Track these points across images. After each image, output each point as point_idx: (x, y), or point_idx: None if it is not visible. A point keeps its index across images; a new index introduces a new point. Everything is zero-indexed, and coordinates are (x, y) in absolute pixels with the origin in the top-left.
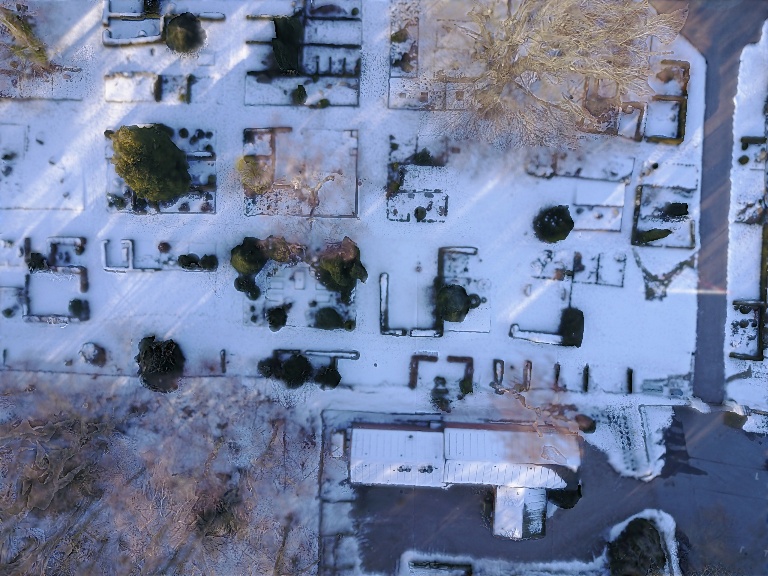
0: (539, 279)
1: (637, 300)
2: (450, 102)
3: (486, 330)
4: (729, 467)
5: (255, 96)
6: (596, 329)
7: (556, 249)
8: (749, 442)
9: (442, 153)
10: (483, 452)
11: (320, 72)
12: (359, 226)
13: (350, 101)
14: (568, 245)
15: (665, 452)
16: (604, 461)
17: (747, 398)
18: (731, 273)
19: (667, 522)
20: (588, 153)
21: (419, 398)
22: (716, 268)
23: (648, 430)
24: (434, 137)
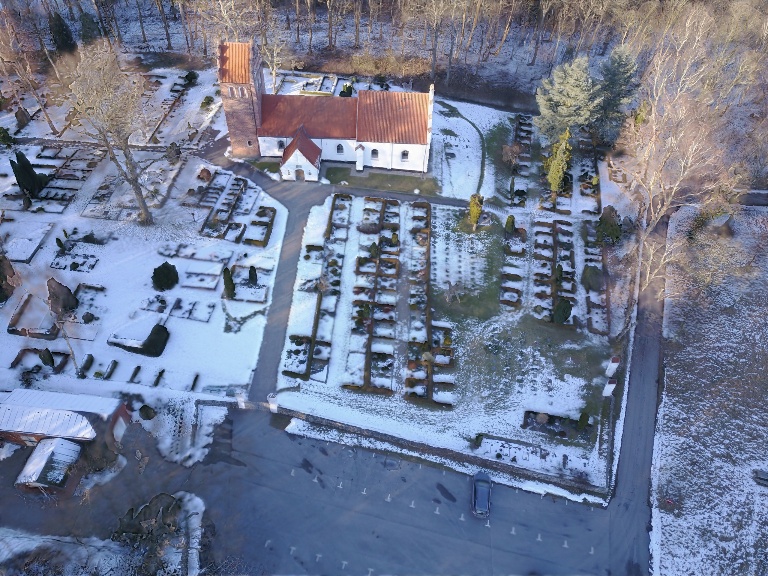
0: (145, 310)
1: (217, 332)
2: (122, 217)
3: (91, 338)
4: (268, 462)
5: (1, 206)
6: (179, 347)
7: (164, 295)
8: (289, 441)
9: (105, 238)
10: (34, 401)
11: (47, 198)
12: (28, 269)
13: (58, 210)
14: (175, 295)
15: (211, 443)
16: (154, 446)
17: (293, 407)
18: (291, 320)
19: (195, 504)
20: (203, 247)
21: (12, 377)
22: (281, 316)
23: (200, 422)
24: (104, 231)
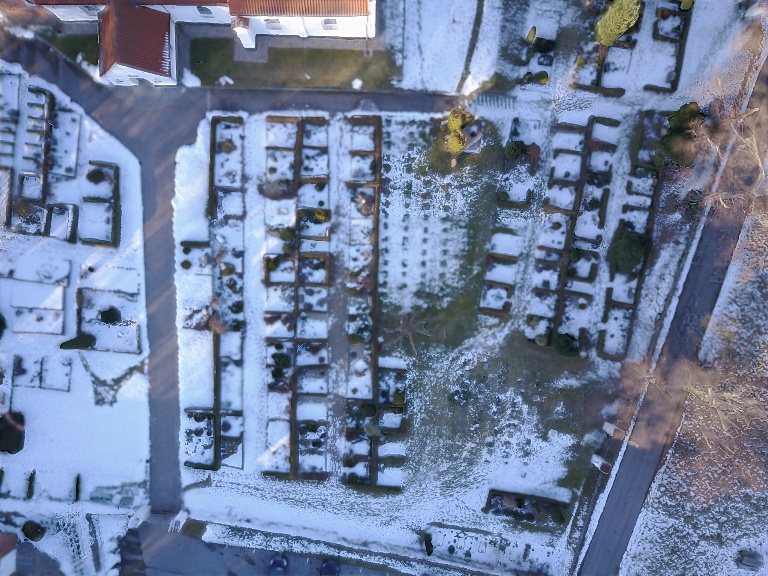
0: None
1: (86, 405)
2: None
3: None
4: None
5: None
6: (42, 434)
7: None
8: (209, 553)
9: None
10: None
11: None
12: None
13: None
14: (9, 347)
15: (119, 561)
16: (56, 569)
17: (206, 508)
18: (182, 380)
19: None
20: (21, 254)
21: None
22: (167, 374)
23: (100, 539)
24: None
